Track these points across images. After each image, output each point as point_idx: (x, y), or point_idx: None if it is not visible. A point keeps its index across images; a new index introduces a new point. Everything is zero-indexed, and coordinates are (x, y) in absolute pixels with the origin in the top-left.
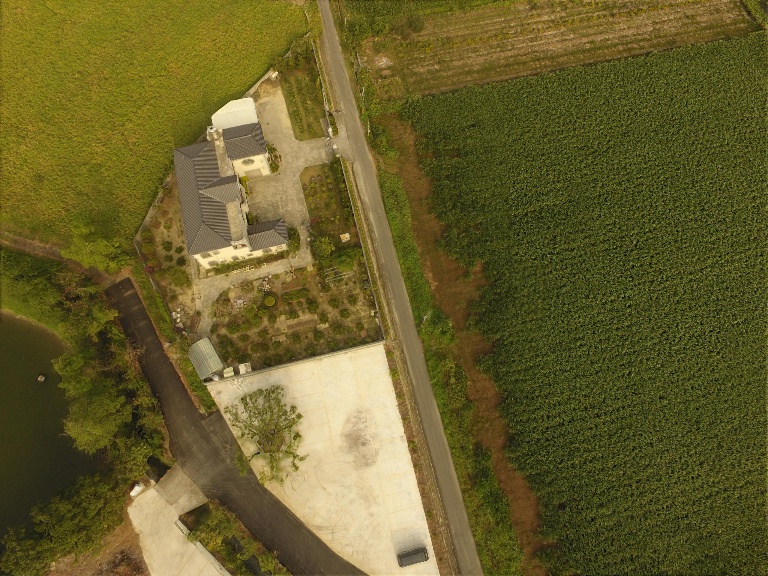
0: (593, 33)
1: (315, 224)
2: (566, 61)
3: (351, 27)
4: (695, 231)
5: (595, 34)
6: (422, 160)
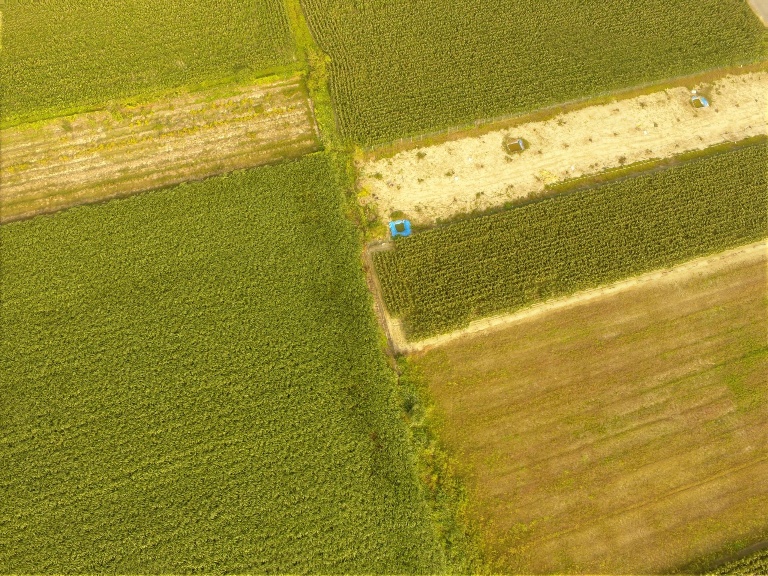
0: (130, 158)
1: None
2: (84, 196)
3: None
4: (142, 421)
5: (131, 160)
6: None
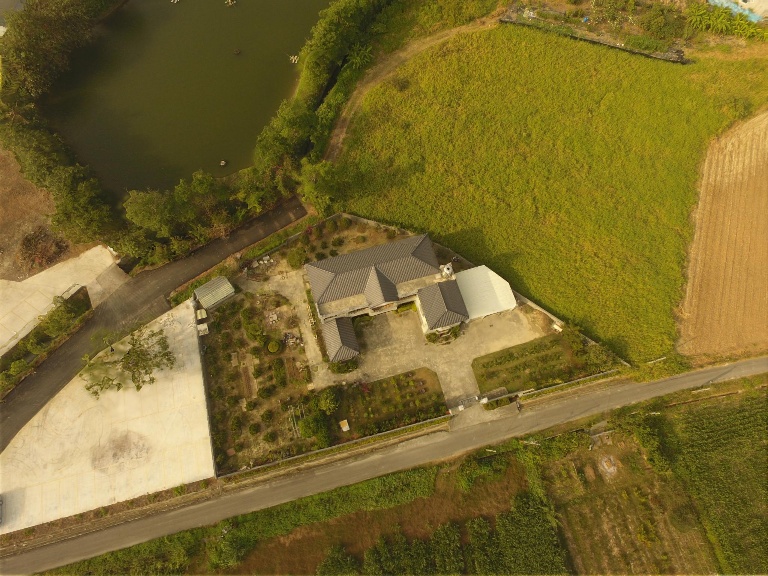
0: None
1: (360, 389)
2: None
3: (656, 420)
4: None
5: None
6: (456, 527)
